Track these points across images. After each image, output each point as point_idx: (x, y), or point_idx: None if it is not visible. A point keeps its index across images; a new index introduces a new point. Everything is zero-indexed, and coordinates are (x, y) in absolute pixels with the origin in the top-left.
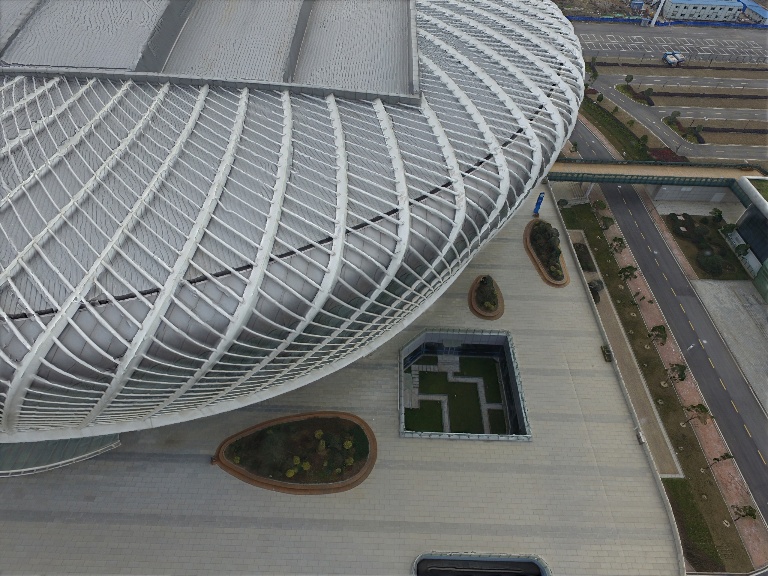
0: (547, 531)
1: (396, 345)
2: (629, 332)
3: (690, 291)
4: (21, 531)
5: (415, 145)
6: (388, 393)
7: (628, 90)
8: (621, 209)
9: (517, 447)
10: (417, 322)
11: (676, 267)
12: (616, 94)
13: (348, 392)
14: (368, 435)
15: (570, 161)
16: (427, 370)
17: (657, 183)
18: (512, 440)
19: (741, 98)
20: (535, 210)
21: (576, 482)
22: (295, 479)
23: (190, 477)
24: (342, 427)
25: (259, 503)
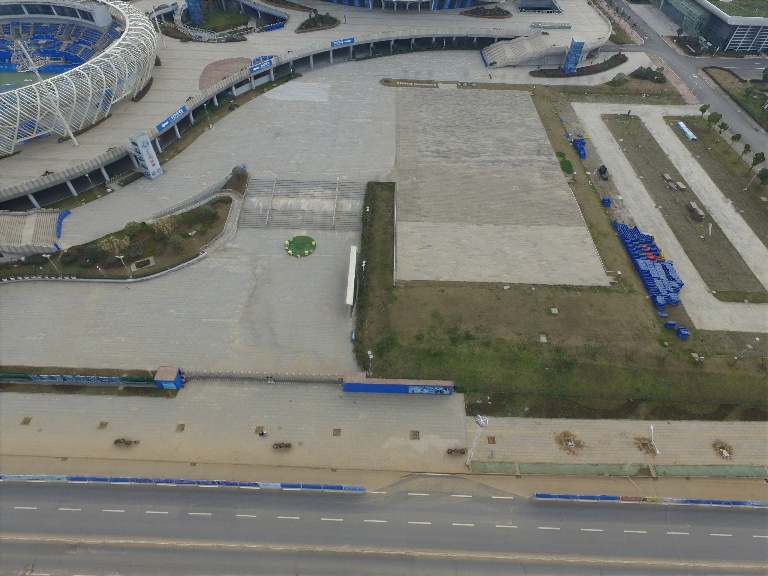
0: None
1: (511, 1)
2: None
3: (626, 6)
4: (410, 20)
5: None
6: None
7: None
8: None
9: (559, 15)
10: None
11: (621, 2)
12: None
13: None
14: None
15: None
16: None
17: None
18: (557, 14)
19: None
20: None
21: (579, 19)
22: (489, 15)
23: (455, 16)
24: None
25: (479, 19)
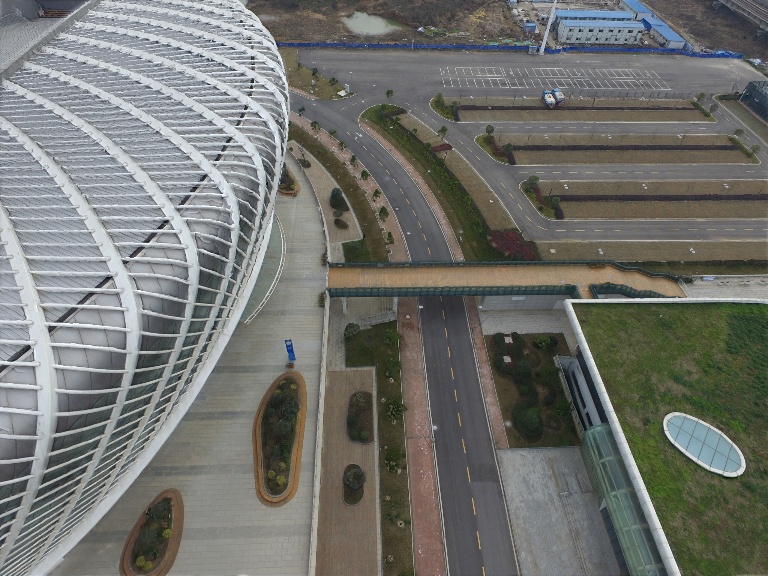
0: None
1: None
2: (387, 559)
3: (492, 471)
4: None
5: None
6: None
7: (489, 144)
8: (435, 328)
9: None
10: None
11: (483, 427)
12: (474, 149)
13: None
14: None
15: (370, 266)
16: None
17: (478, 294)
18: None
19: (621, 149)
20: (290, 357)
21: None
22: None
23: None
24: None
25: None
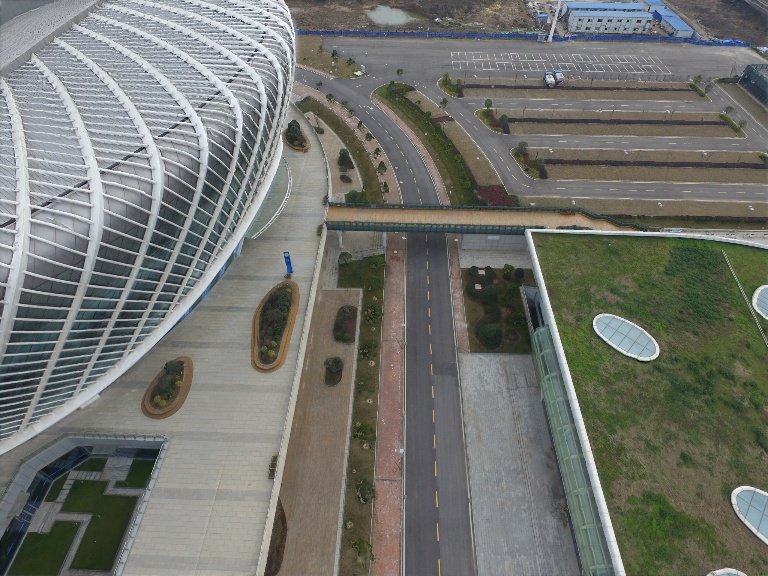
0: None
1: (22, 455)
2: (355, 425)
3: (452, 368)
4: None
5: None
6: None
7: (487, 116)
8: (418, 261)
9: None
10: (67, 422)
11: (450, 336)
12: (473, 121)
13: None
14: None
15: (364, 206)
16: (85, 478)
17: (456, 232)
18: None
19: (612, 123)
20: (288, 270)
21: None
22: None
23: None
24: None
25: None
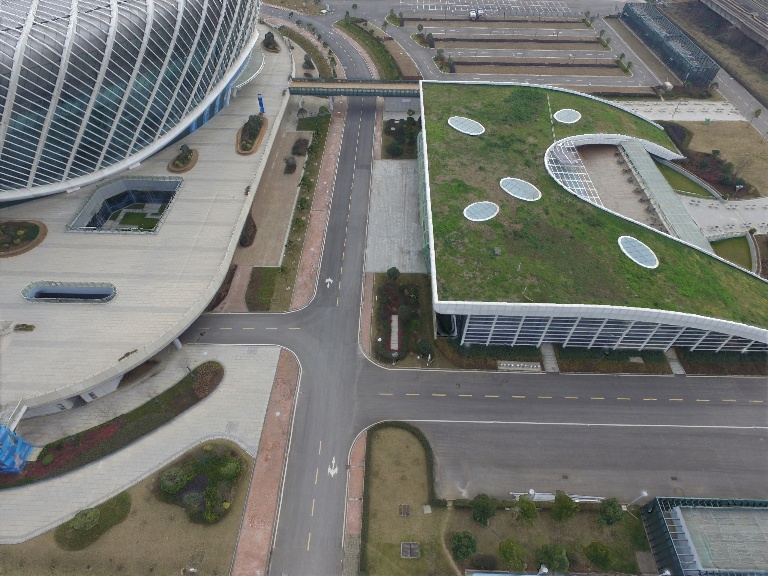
0: (132, 276)
1: None
2: (302, 190)
3: (368, 166)
4: None
5: (10, 7)
6: (72, 211)
7: (419, 37)
8: (354, 117)
9: (144, 237)
10: (121, 174)
11: (369, 152)
12: (408, 40)
13: (44, 210)
14: (41, 230)
15: (317, 81)
16: (132, 212)
17: (380, 95)
18: (142, 234)
19: (513, 42)
20: (261, 110)
21: (172, 254)
22: None
23: None
24: (24, 225)
25: None
